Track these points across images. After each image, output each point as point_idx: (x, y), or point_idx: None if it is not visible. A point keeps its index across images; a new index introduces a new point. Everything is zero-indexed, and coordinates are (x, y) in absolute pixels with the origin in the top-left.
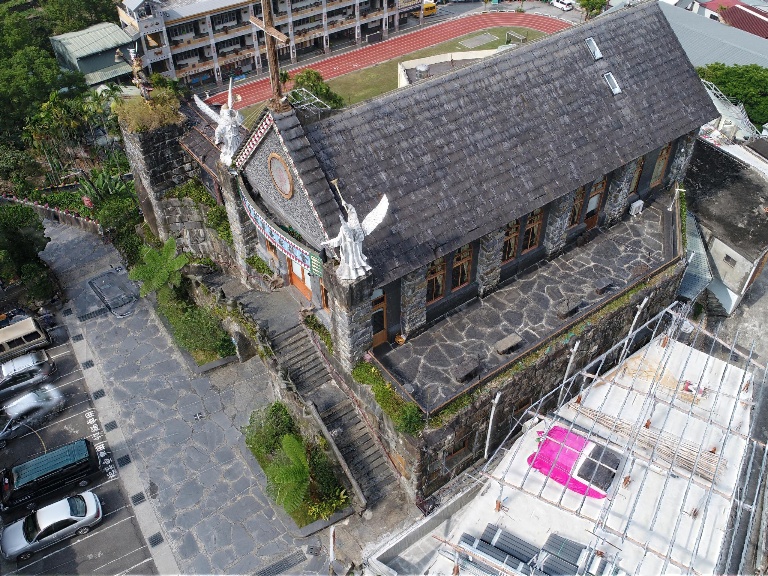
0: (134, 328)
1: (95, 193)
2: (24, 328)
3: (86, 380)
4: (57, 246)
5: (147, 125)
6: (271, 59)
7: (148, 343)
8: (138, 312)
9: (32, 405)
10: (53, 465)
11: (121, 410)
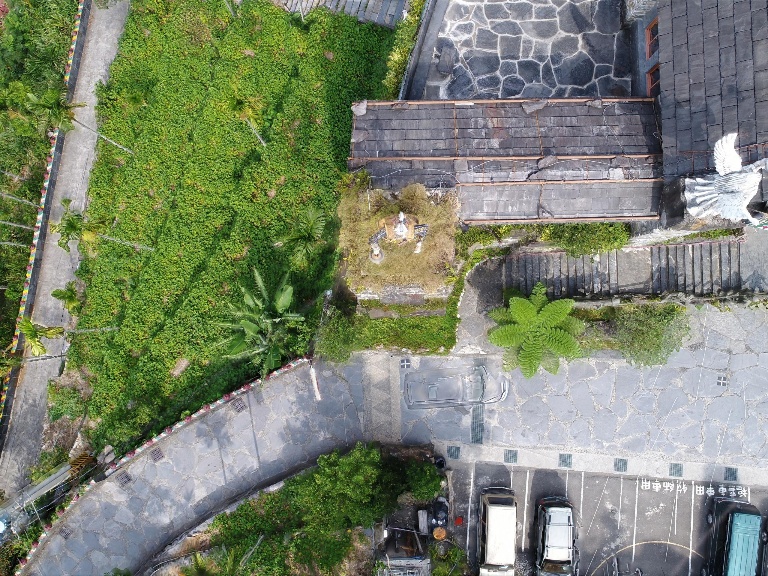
0: (537, 390)
1: (264, 342)
2: (508, 520)
3: (589, 471)
4: (297, 420)
5: (443, 261)
6: None
7: (573, 385)
8: (509, 374)
9: (592, 537)
10: (753, 553)
11: (660, 452)
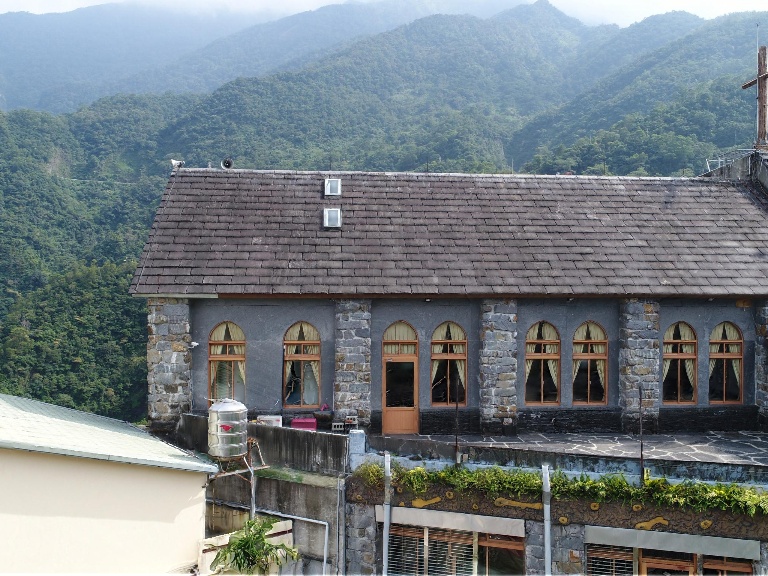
0: None
1: None
2: None
3: None
4: None
5: None
6: (764, 103)
7: None
8: None
9: None
10: None
11: None
